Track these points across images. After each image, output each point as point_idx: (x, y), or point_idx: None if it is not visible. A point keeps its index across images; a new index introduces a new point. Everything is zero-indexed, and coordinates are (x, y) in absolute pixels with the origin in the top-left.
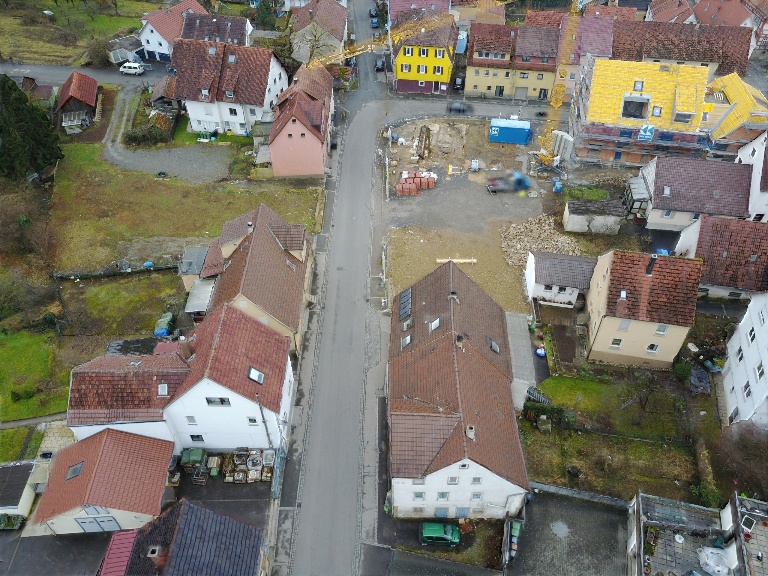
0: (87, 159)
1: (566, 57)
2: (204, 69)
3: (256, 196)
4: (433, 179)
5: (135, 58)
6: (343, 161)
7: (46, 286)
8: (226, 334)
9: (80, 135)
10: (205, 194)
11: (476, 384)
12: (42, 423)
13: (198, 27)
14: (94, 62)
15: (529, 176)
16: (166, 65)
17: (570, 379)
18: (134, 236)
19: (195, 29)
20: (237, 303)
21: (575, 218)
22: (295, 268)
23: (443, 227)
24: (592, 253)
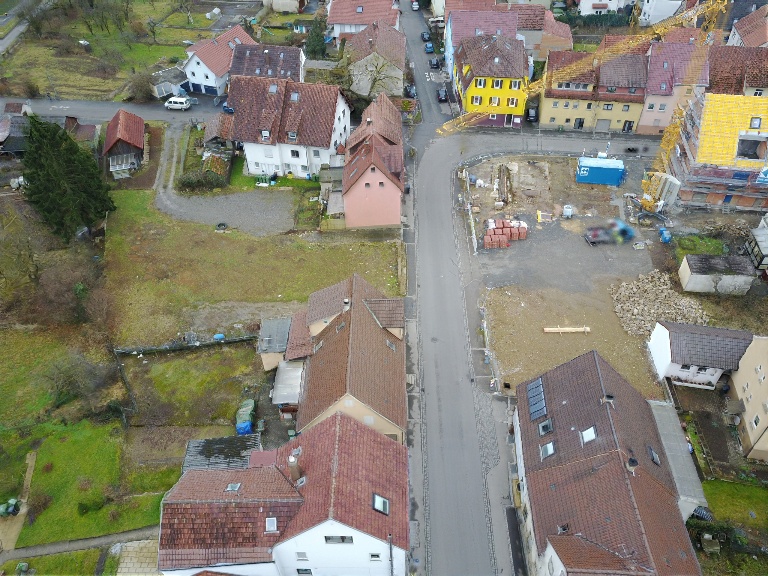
0: (139, 208)
1: (657, 87)
2: (264, 108)
3: (328, 251)
4: (524, 229)
5: (180, 92)
6: (418, 207)
7: (106, 363)
8: (344, 454)
9: (128, 180)
10: (272, 249)
11: (655, 519)
12: (116, 544)
13: (248, 58)
14: (136, 96)
15: (629, 223)
16: (214, 99)
17: (729, 484)
18: (199, 301)
19: (245, 61)
20: (342, 402)
21: (698, 277)
22: (395, 349)
23: (543, 287)
24: (721, 319)
